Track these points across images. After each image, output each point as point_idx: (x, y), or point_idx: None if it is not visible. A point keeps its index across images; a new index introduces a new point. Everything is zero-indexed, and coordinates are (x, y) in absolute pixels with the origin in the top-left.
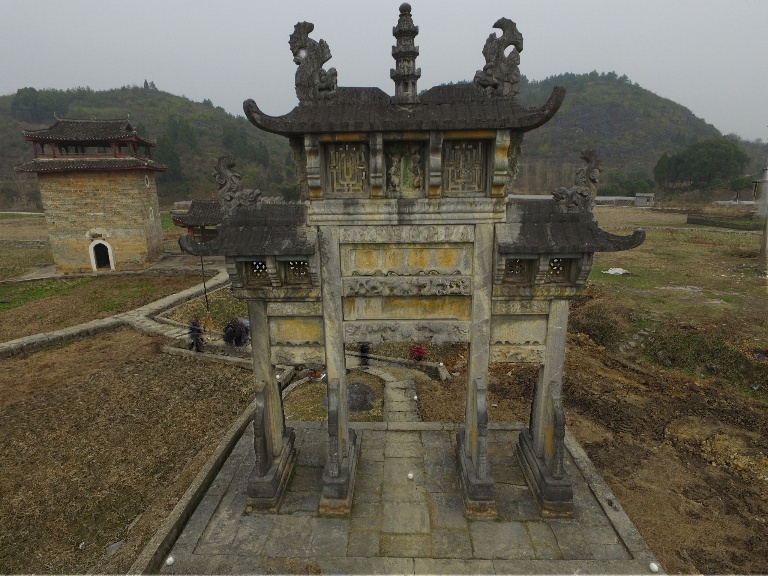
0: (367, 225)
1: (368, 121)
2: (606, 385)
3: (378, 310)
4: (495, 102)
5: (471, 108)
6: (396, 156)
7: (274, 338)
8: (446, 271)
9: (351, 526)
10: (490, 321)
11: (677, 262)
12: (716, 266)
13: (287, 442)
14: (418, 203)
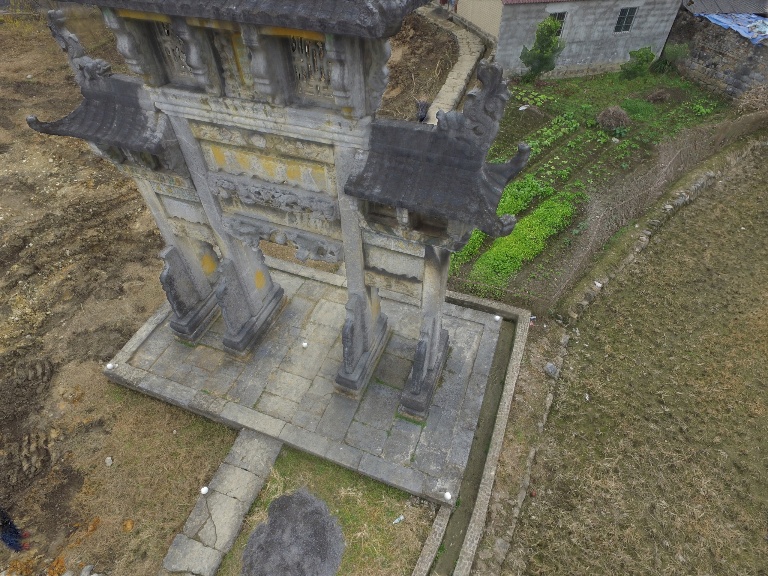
0: None
1: None
2: None
3: None
4: None
5: None
6: None
7: None
8: None
9: None
10: None
11: None
12: None
13: (411, 372)
14: None
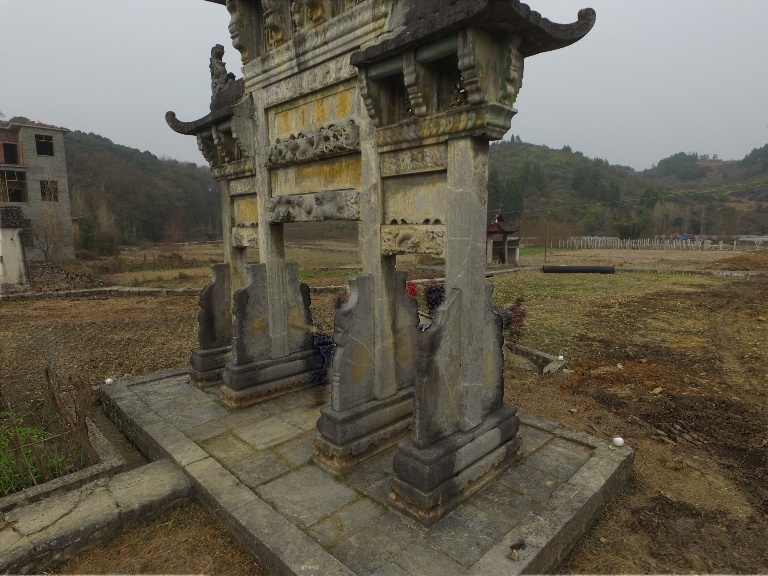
0: (280, 81)
1: None
2: None
3: (293, 183)
4: None
5: None
6: None
7: (236, 220)
8: (342, 123)
9: (222, 417)
10: (382, 188)
11: None
12: None
13: None
14: (308, 37)
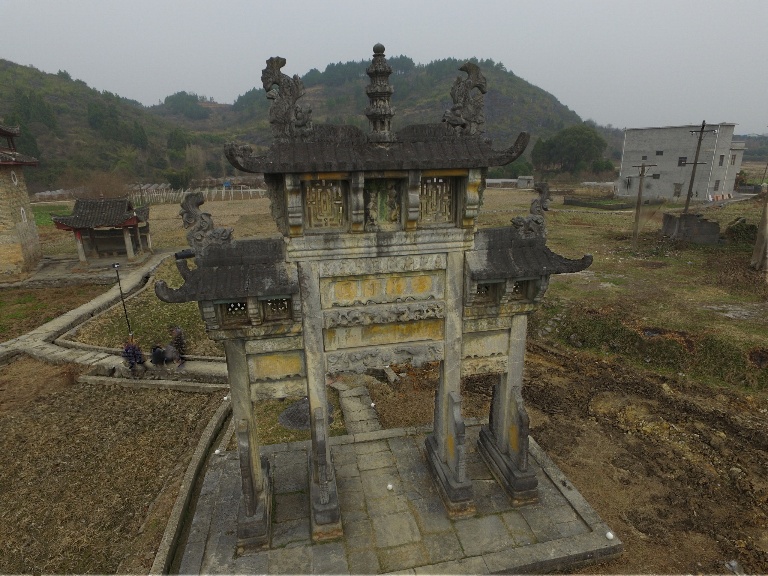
0: (347, 258)
1: (350, 161)
2: (533, 370)
3: (358, 338)
4: (464, 141)
5: (443, 147)
6: (373, 191)
7: (253, 375)
8: (421, 297)
9: (347, 548)
10: (461, 339)
11: (569, 247)
12: (600, 250)
13: (266, 474)
14: (396, 236)
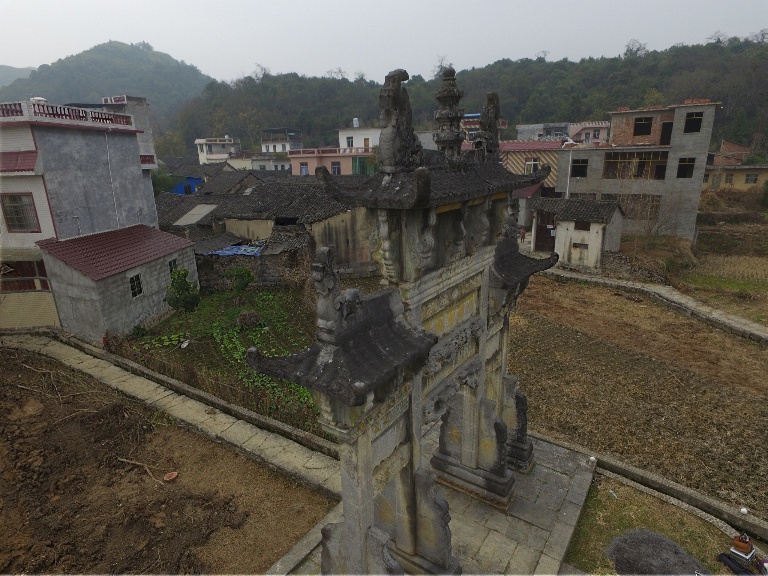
0: None
1: None
2: None
3: None
4: None
5: None
6: None
7: None
8: None
9: None
10: None
11: None
12: None
13: None
14: None
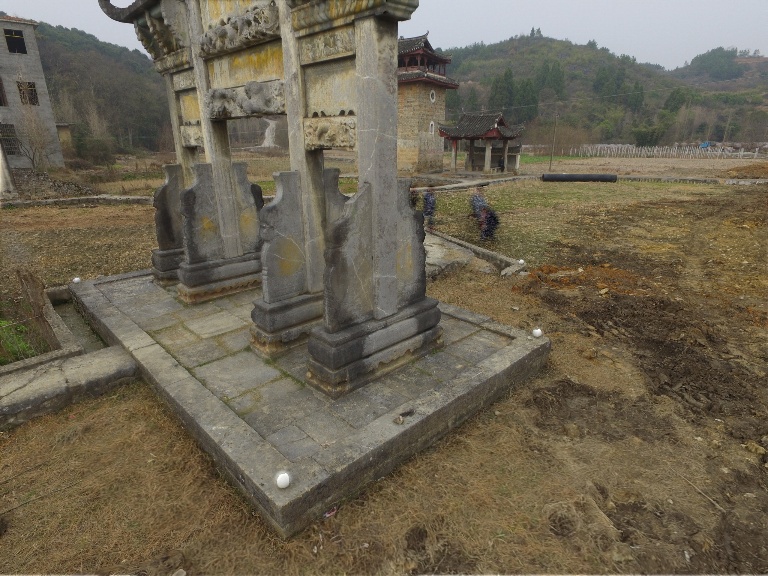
0: None
1: None
2: None
3: (227, 75)
4: None
5: None
6: None
7: (184, 118)
8: (264, 4)
9: (177, 311)
10: (303, 78)
11: None
12: None
13: None
14: None
